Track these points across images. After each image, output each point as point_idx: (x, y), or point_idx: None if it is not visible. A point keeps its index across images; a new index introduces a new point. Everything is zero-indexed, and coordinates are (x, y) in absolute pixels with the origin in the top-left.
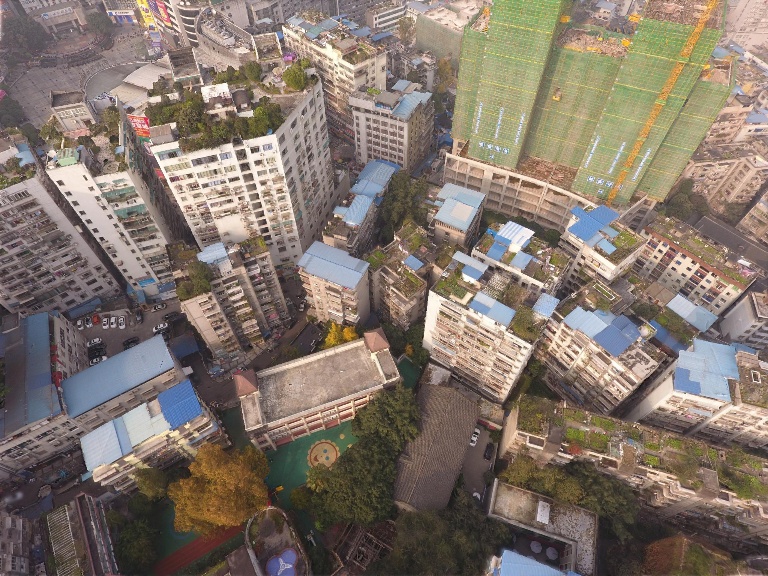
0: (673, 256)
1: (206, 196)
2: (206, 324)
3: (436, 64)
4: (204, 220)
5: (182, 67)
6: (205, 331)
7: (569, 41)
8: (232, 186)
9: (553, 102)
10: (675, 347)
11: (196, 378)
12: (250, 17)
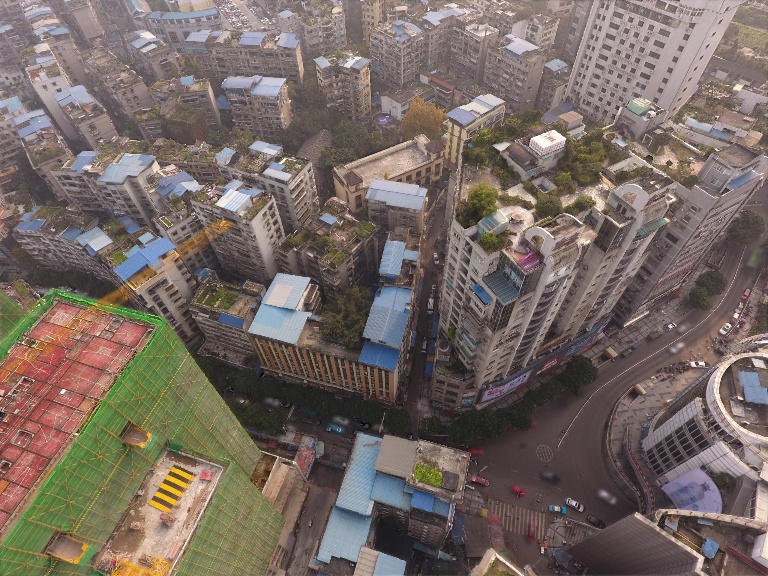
0: None
1: None
2: None
3: None
4: None
5: None
6: None
7: None
8: None
9: None
10: (126, 219)
11: None
12: None
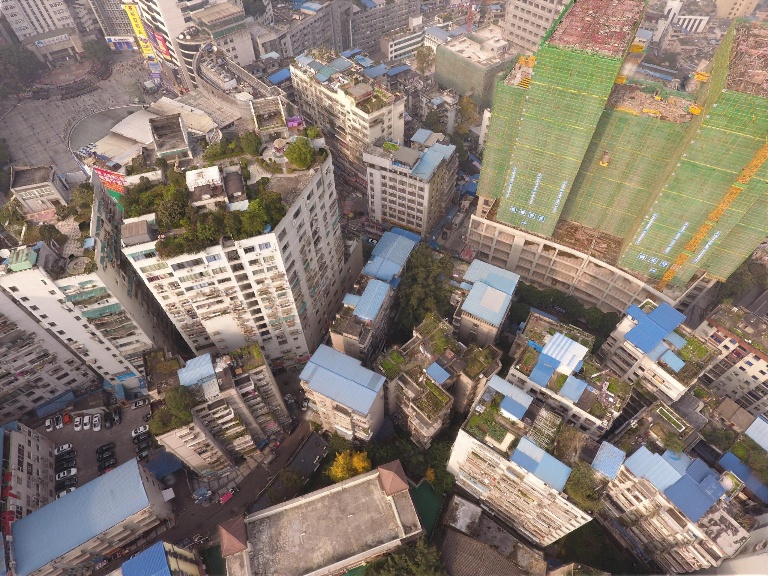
0: (743, 355)
1: (191, 299)
2: (188, 451)
3: (458, 103)
4: (191, 316)
5: (168, 137)
6: (187, 457)
7: (621, 100)
8: (222, 287)
9: (599, 167)
10: (759, 491)
11: (178, 501)
12: (256, 49)
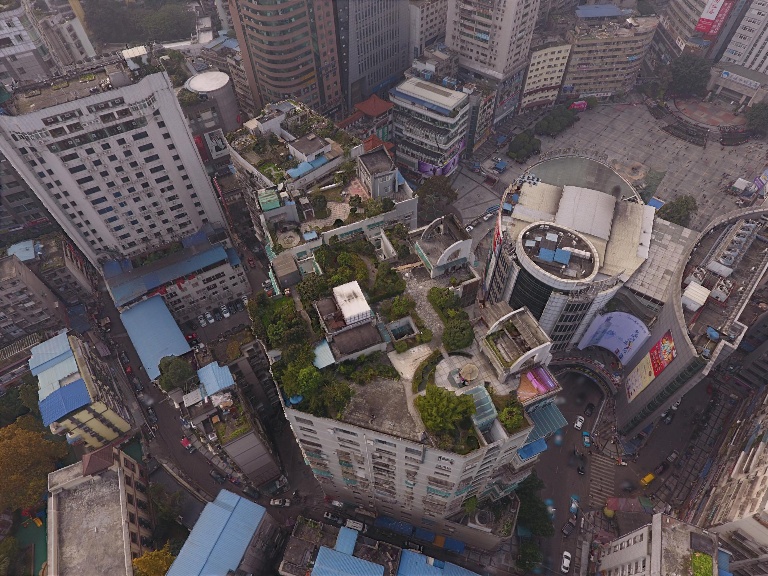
0: None
1: None
2: None
3: None
4: None
5: (448, 241)
6: None
7: None
8: None
9: None
10: None
11: None
12: None
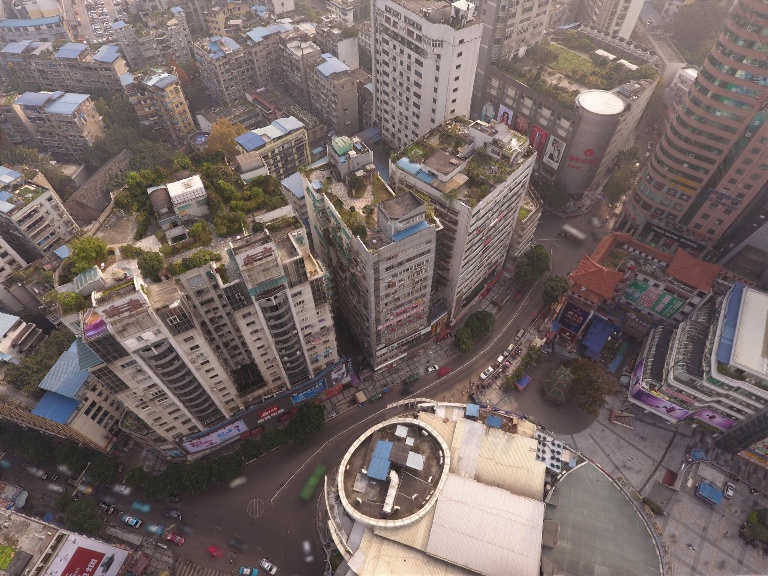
0: None
1: None
2: None
3: None
4: None
5: None
6: None
7: None
8: None
9: None
10: None
11: None
12: None
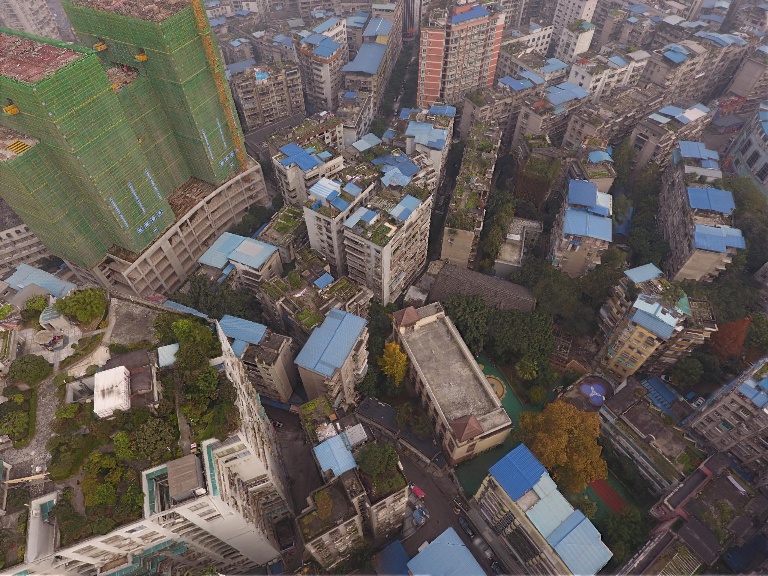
0: None
1: None
2: None
3: None
4: None
5: None
6: None
7: None
8: None
9: None
10: None
11: None
12: None
